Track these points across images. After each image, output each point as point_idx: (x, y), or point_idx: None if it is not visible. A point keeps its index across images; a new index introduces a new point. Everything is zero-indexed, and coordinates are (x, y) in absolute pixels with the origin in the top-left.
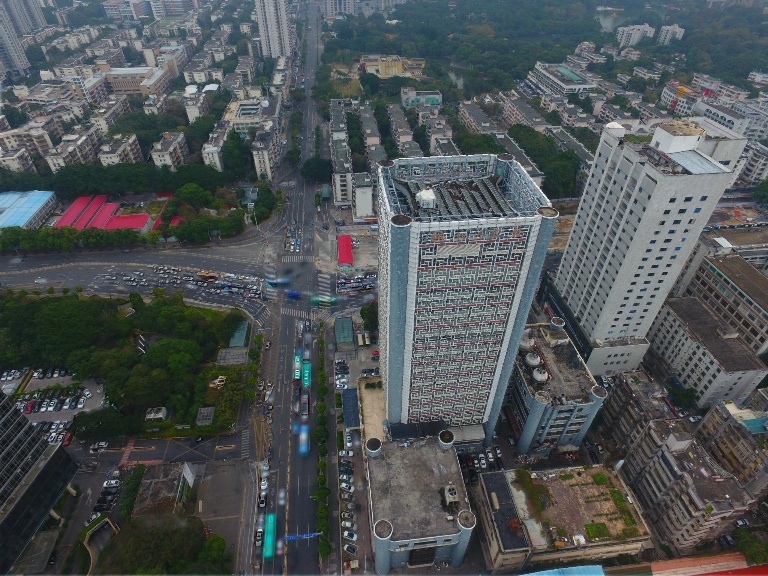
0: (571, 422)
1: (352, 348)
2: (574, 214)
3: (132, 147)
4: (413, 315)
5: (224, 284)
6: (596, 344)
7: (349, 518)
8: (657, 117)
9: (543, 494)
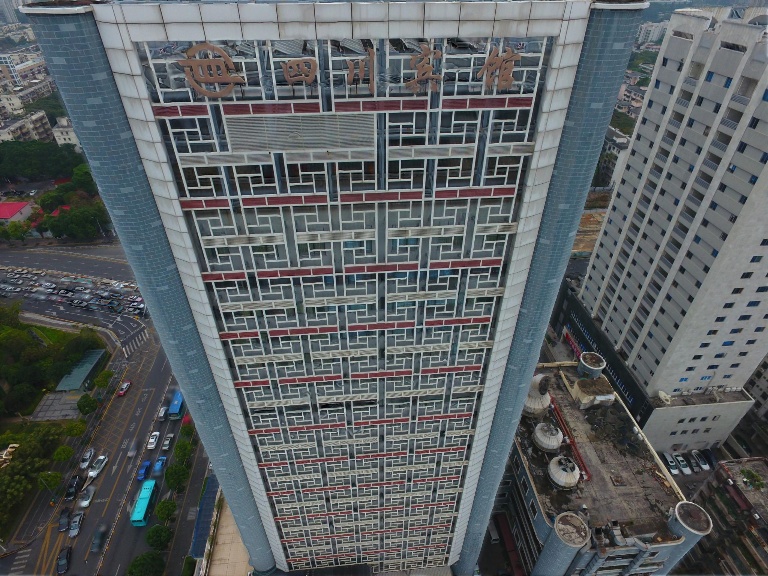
0: (629, 573)
1: None
2: (598, 208)
3: (36, 125)
4: (220, 350)
5: (96, 294)
6: (659, 400)
7: None
8: None
9: None
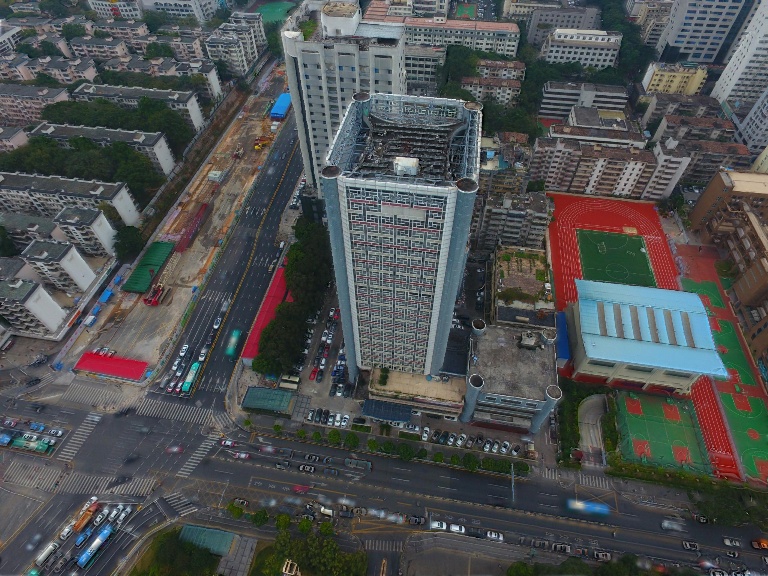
0: None
1: (294, 399)
2: (211, 150)
3: None
4: None
5: (63, 568)
6: None
7: (490, 444)
8: (133, 29)
9: (514, 291)
